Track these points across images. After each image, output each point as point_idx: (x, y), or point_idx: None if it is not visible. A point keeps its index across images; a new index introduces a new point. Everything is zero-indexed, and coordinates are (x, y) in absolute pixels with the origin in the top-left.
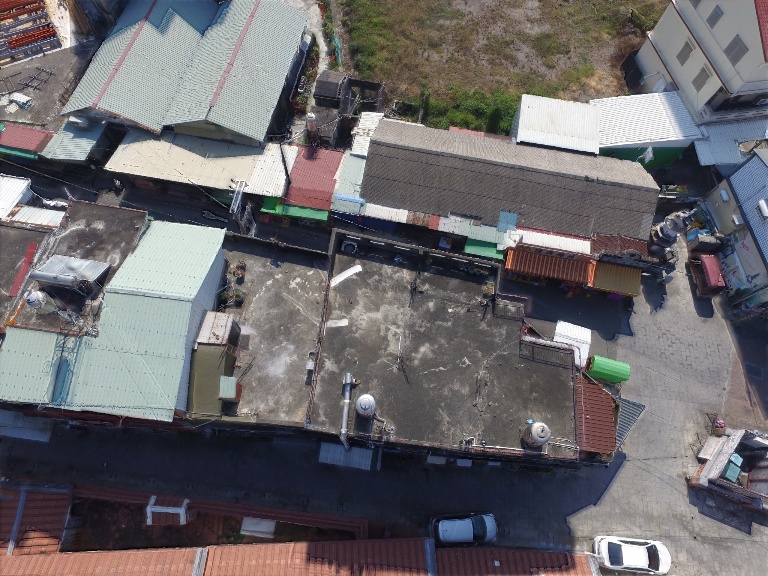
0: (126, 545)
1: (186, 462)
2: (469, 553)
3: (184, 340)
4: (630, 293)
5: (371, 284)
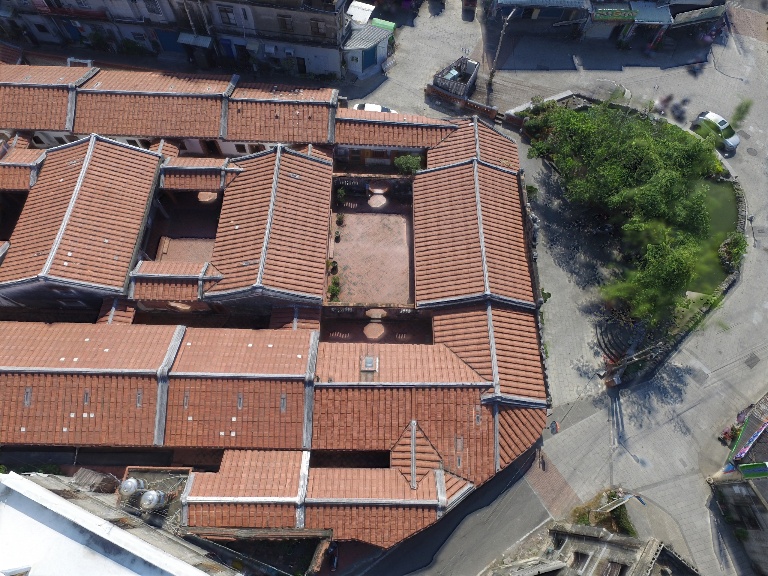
0: None
1: None
2: (260, 84)
3: None
4: None
5: None
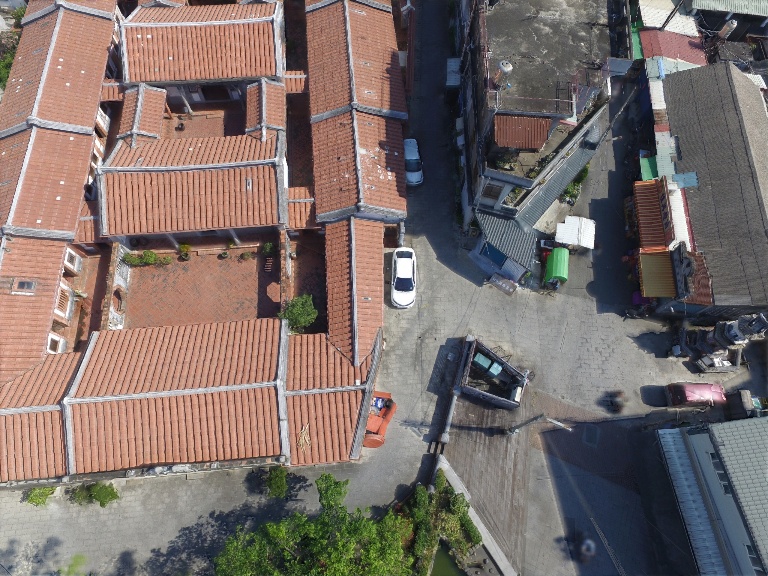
0: None
1: (433, 20)
2: (401, 140)
3: None
4: (644, 287)
5: (589, 2)
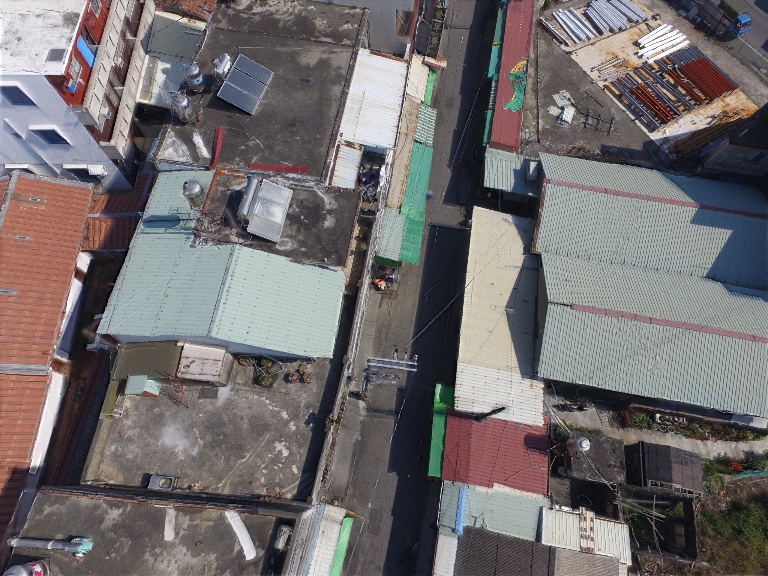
0: (99, 299)
1: None
2: None
3: (170, 333)
4: None
5: None
